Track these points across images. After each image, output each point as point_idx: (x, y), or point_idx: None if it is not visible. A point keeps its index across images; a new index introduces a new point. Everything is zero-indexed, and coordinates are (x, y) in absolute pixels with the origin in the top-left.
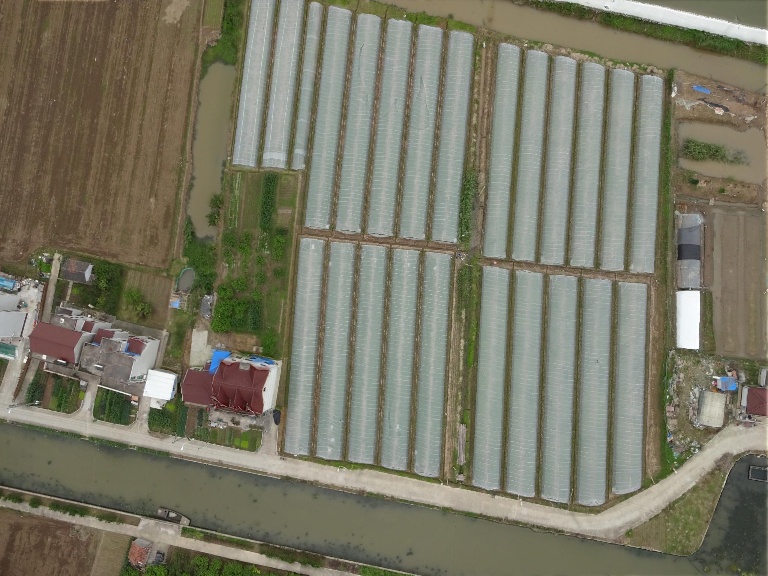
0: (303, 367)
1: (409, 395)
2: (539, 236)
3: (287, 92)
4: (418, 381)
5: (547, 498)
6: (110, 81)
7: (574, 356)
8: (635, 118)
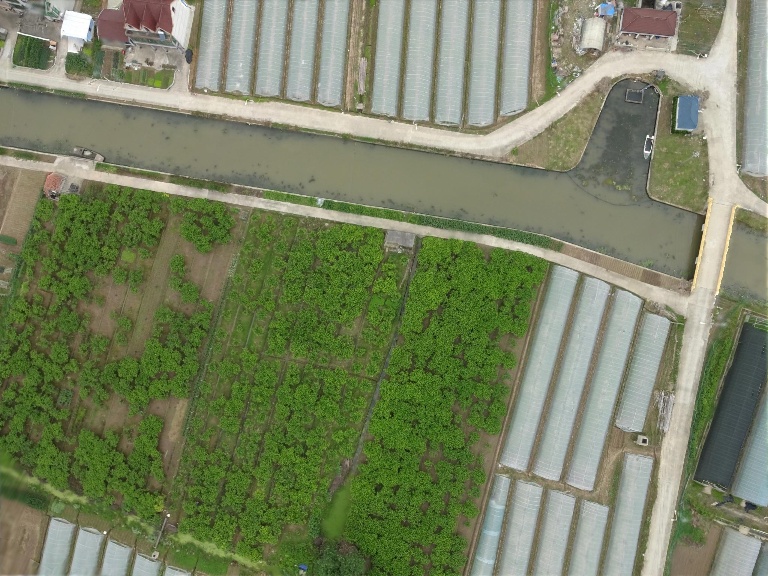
0: (216, 14)
1: (314, 32)
2: None
3: None
4: (323, 20)
5: (440, 123)
6: None
7: None
8: None
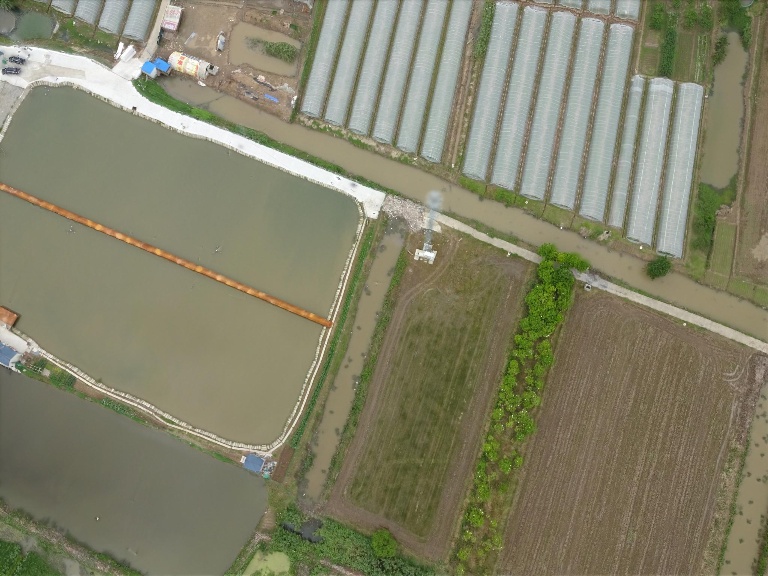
0: None
1: None
2: (426, 1)
3: None
4: None
5: None
6: None
7: None
8: (330, 84)
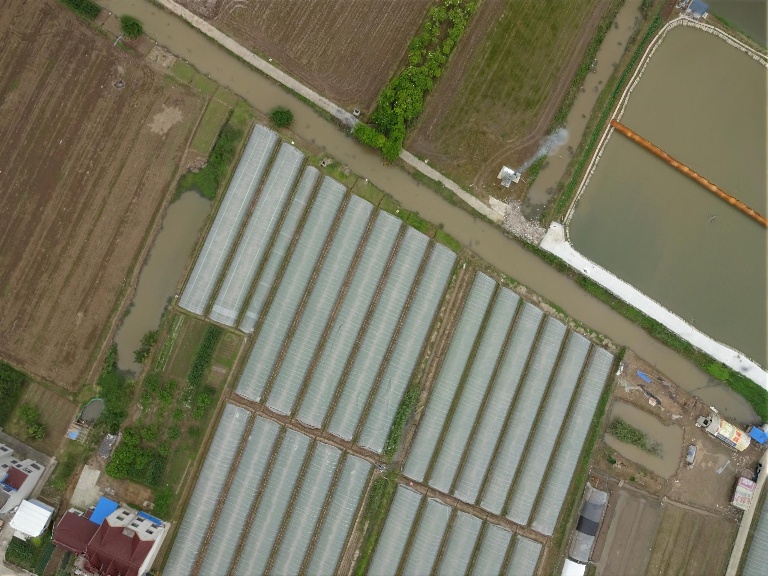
0: (191, 534)
1: None
2: (460, 469)
3: (257, 249)
4: None
5: None
6: (70, 171)
7: None
8: (579, 383)
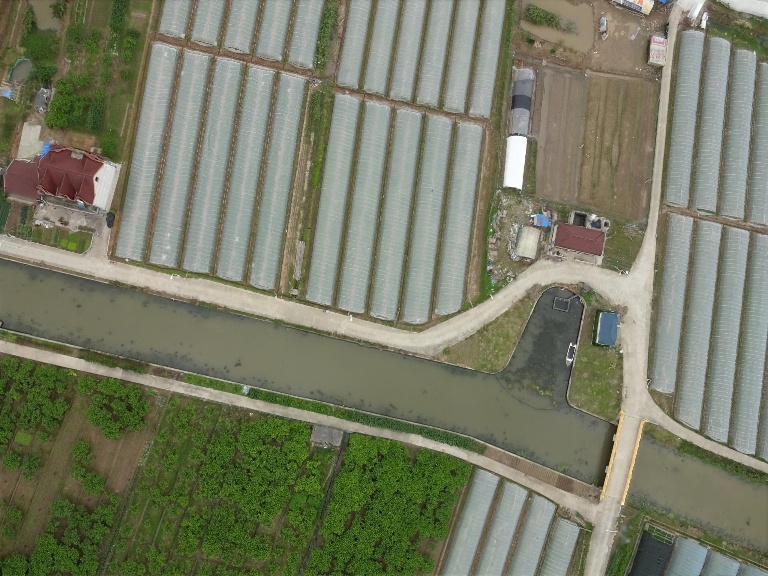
0: (144, 174)
1: (251, 209)
2: (391, 73)
3: None
4: (262, 197)
5: (375, 316)
6: None
7: (412, 186)
8: None
